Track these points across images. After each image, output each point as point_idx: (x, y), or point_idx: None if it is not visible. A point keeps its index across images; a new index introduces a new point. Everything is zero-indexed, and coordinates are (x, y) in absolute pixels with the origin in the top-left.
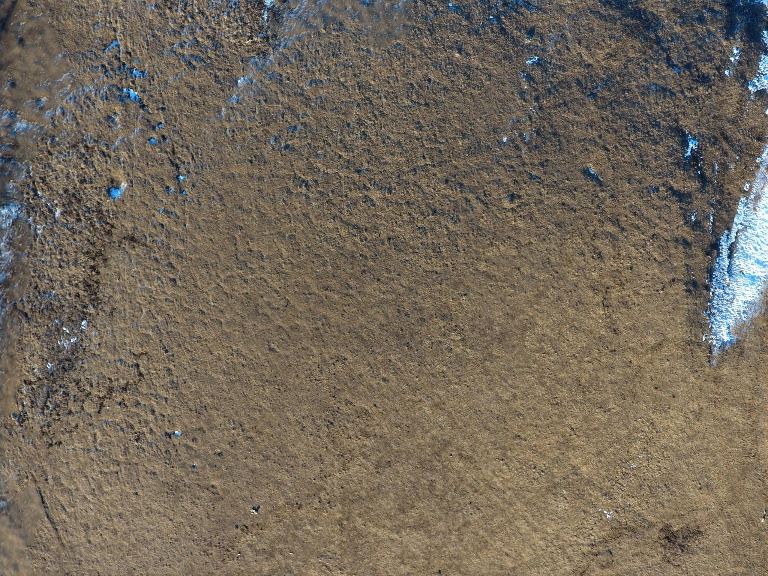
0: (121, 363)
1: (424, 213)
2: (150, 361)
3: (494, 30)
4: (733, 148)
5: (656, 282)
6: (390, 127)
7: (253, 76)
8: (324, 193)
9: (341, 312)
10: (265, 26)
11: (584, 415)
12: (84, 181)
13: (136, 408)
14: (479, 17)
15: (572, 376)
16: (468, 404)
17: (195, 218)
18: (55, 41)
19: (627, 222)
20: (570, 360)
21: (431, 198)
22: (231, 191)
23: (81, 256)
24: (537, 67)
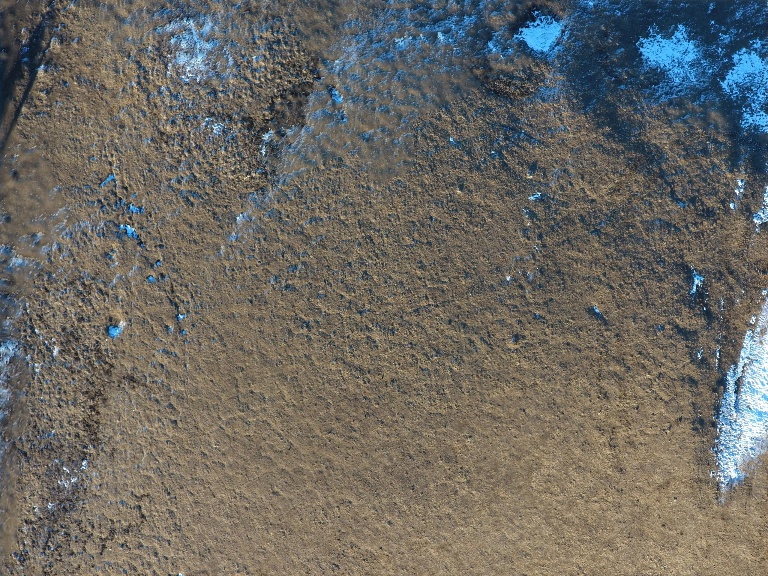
0: (123, 505)
1: (427, 354)
2: (152, 503)
3: (496, 166)
4: (739, 282)
5: (663, 421)
6: (392, 267)
7: (252, 213)
8: (326, 334)
9: (345, 455)
10: (263, 161)
11: (591, 554)
12: (82, 319)
13: (139, 550)
14: (480, 152)
15: (579, 516)
16: (474, 545)
17: (195, 359)
18: (50, 174)
19: (633, 361)
20: (577, 500)
21: (434, 339)
22: (231, 331)
23: (80, 396)
24: (540, 203)
